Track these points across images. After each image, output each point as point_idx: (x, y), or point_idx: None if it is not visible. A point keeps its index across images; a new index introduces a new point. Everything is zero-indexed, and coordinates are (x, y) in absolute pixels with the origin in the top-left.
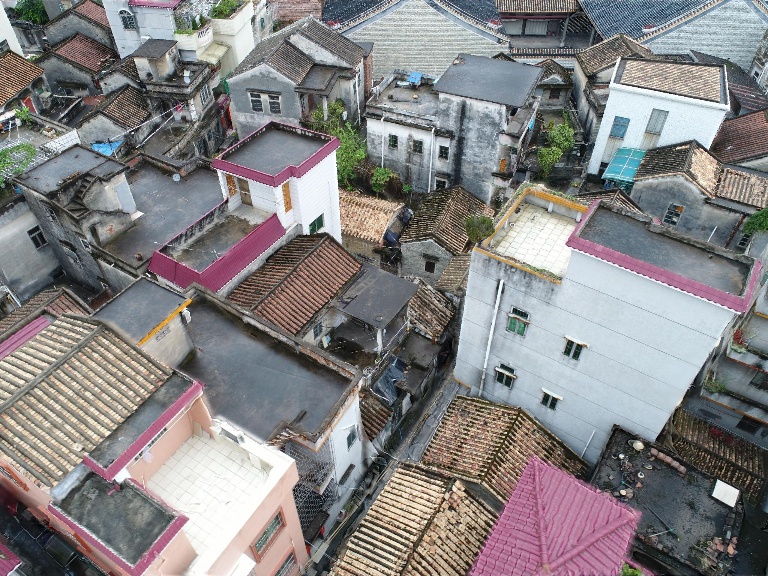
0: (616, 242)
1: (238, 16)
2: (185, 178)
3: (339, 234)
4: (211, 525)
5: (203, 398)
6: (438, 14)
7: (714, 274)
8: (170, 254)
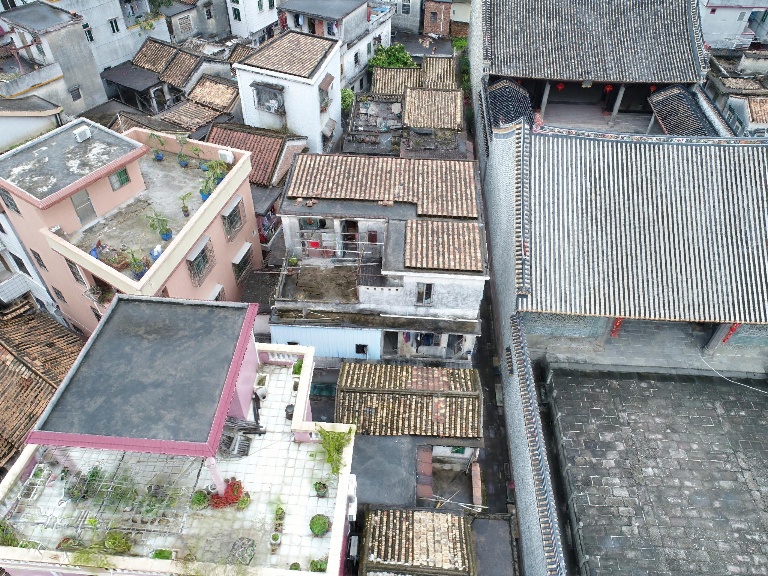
0: None
1: None
2: None
3: (252, 24)
4: None
5: None
6: None
7: None
8: None
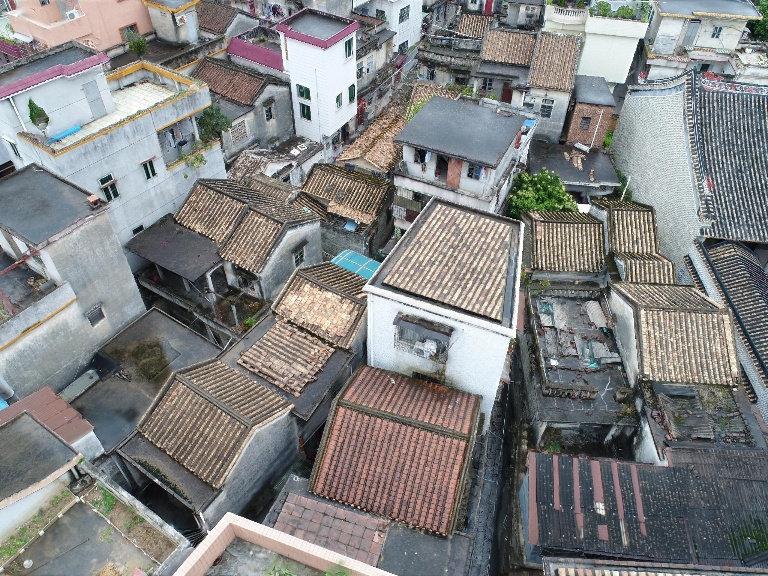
0: (63, 58)
1: (605, 21)
2: (363, 42)
3: (327, 126)
4: (21, 2)
5: (149, 51)
6: (683, 128)
7: (5, 81)
8: (268, 37)
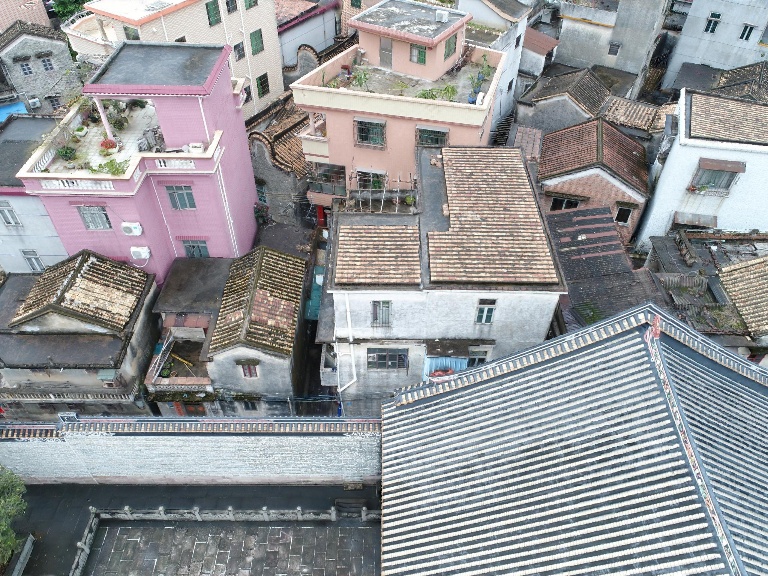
0: None
1: None
2: None
3: None
4: None
5: None
6: None
7: None
8: None
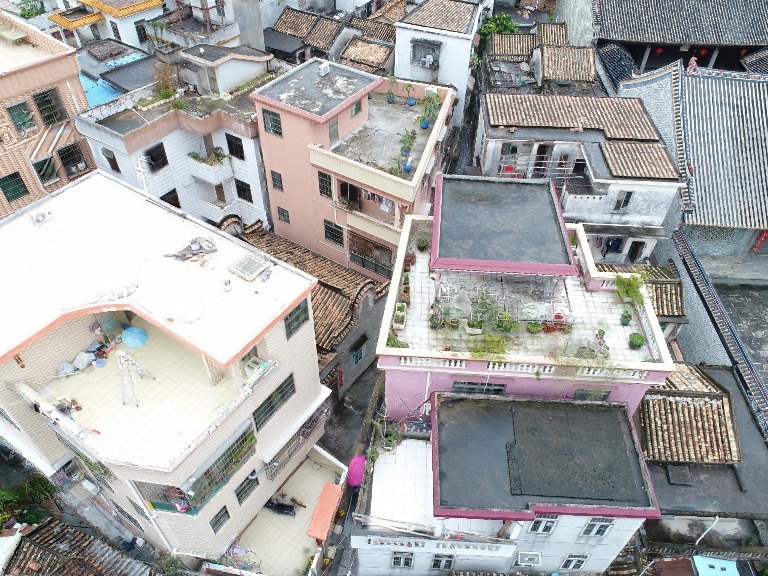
0: None
1: None
2: None
3: None
4: None
5: None
6: None
7: None
8: None
